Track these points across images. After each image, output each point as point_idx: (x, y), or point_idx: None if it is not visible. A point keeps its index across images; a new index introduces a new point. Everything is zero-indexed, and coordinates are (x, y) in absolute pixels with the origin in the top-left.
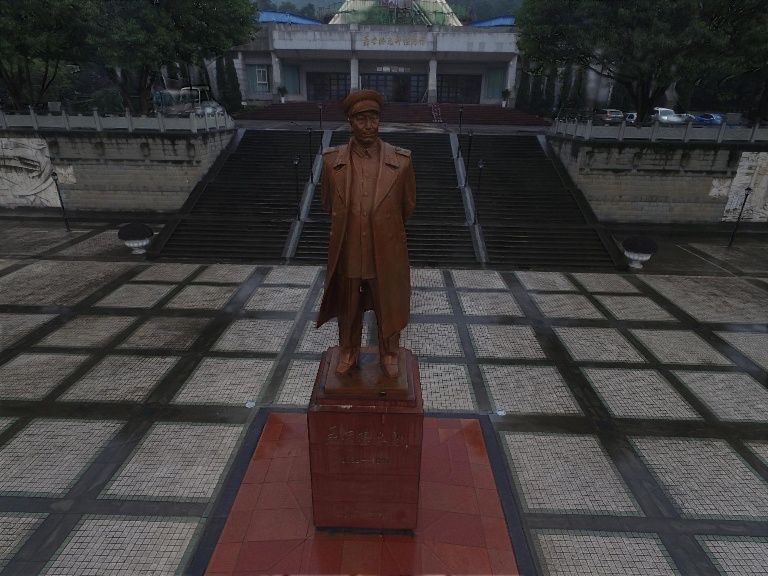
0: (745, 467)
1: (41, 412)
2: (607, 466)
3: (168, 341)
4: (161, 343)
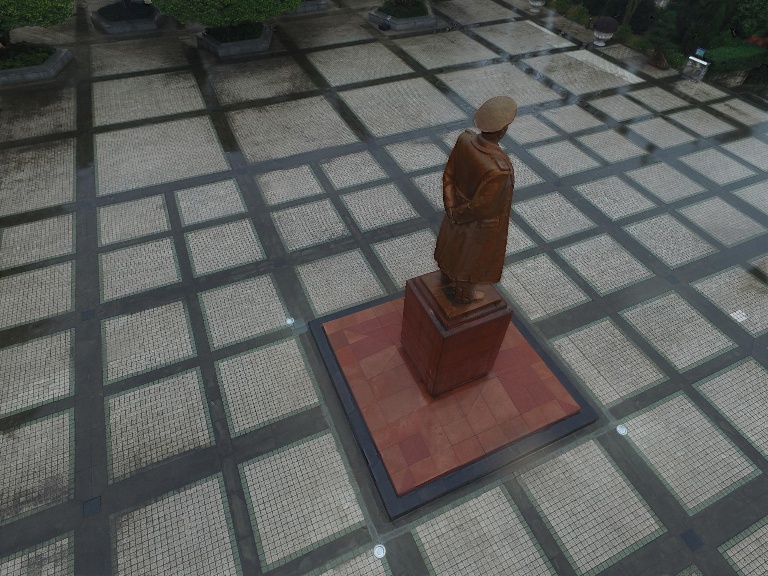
0: (295, 209)
1: None
2: (325, 261)
3: None
4: None
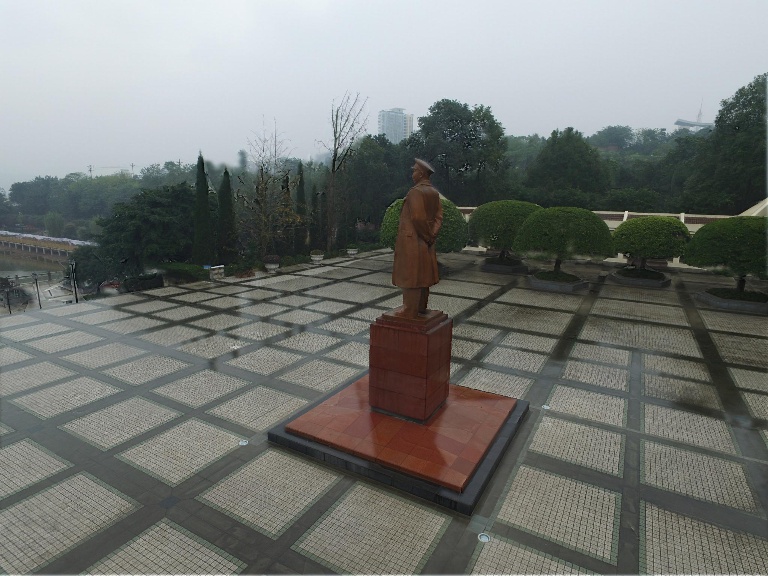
0: None
1: (556, 357)
2: (354, 569)
3: (658, 389)
4: (654, 386)
